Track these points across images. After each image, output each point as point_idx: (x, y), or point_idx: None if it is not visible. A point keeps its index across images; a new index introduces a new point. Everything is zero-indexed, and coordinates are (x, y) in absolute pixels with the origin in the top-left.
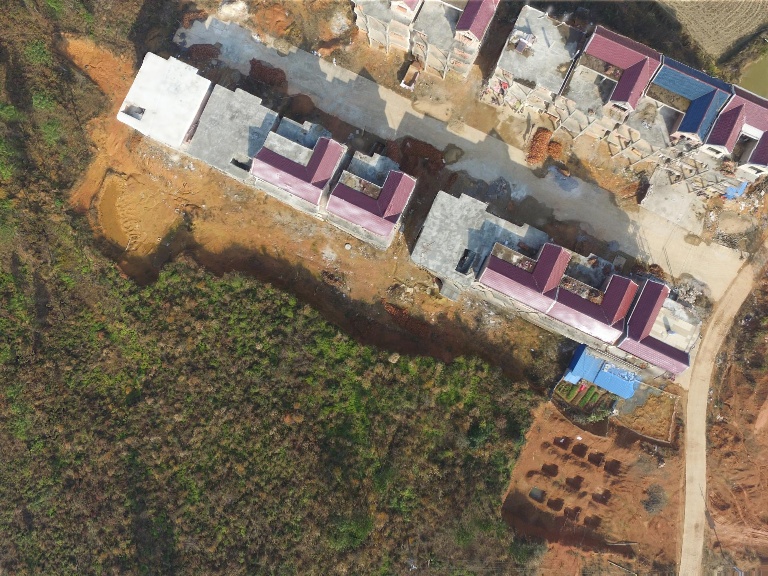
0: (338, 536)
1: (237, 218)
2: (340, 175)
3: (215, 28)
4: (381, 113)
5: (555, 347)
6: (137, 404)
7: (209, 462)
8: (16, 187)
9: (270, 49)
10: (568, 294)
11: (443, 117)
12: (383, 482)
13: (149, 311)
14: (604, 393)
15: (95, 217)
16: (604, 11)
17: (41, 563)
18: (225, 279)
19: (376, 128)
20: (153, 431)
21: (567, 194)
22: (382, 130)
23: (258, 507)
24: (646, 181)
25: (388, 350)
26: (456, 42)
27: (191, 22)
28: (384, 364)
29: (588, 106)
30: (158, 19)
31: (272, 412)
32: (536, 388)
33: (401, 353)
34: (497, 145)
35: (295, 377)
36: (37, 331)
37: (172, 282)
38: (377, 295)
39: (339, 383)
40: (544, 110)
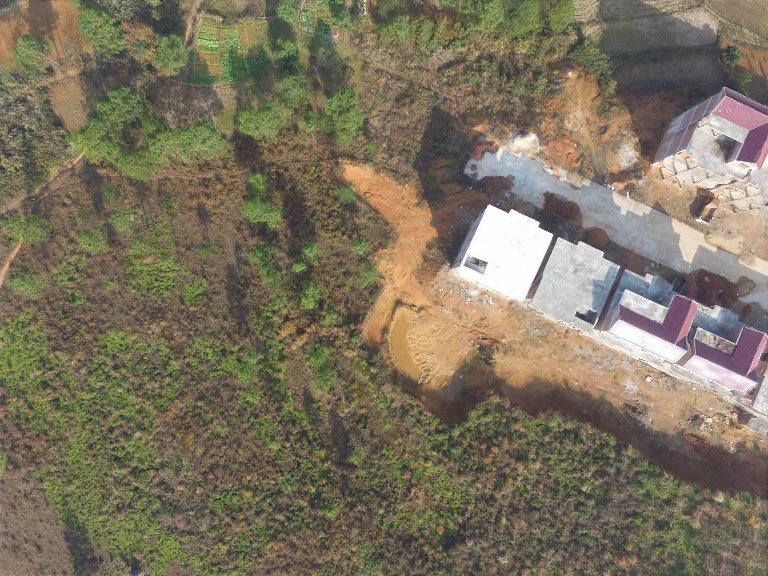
0: None
1: (538, 352)
2: (695, 332)
3: (507, 160)
4: (675, 246)
5: None
6: (456, 546)
7: None
8: (304, 321)
9: (563, 182)
10: None
11: (735, 250)
12: None
13: (460, 450)
14: None
15: (387, 350)
16: None
17: None
18: (541, 419)
19: (671, 261)
20: (479, 575)
21: None
22: (677, 263)
23: None
24: None
25: (708, 487)
26: None
27: (482, 154)
28: (709, 502)
29: None
30: (445, 149)
31: (606, 555)
32: None
33: (717, 488)
34: None
35: (624, 518)
36: (344, 473)
37: (483, 421)
38: (678, 426)
39: (669, 524)
40: None
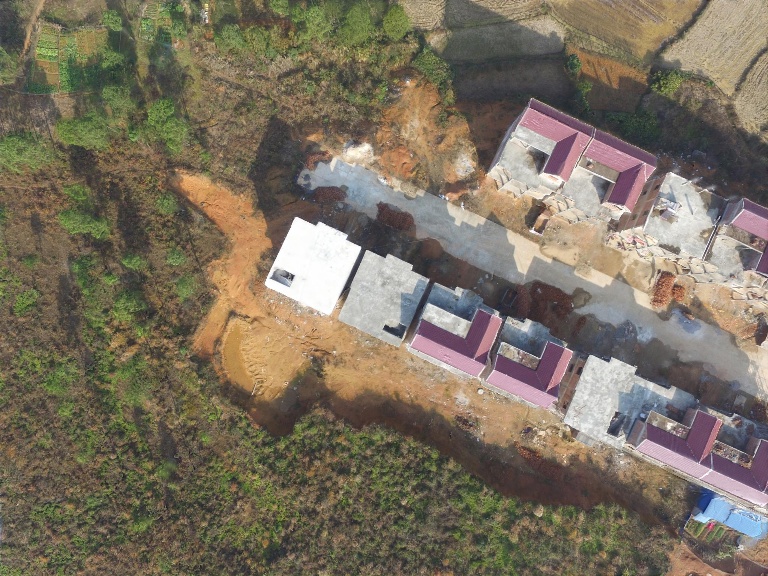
0: None
1: (369, 364)
2: (498, 346)
3: (340, 170)
4: (510, 257)
5: (683, 486)
6: (278, 560)
7: None
8: (135, 332)
9: (397, 192)
10: (721, 460)
11: (571, 262)
12: None
13: (285, 463)
14: (730, 530)
15: (219, 362)
16: (722, 157)
17: None
18: (364, 432)
19: (505, 272)
20: None
21: (690, 336)
22: (511, 274)
23: None
24: (764, 322)
25: (531, 501)
26: (603, 208)
27: (316, 164)
28: (529, 517)
29: (730, 271)
30: (280, 159)
31: (422, 569)
32: (666, 527)
33: (542, 502)
34: (623, 289)
35: (442, 532)
36: (168, 486)
37: (308, 434)
38: (510, 439)
39: (487, 538)
40: (673, 260)
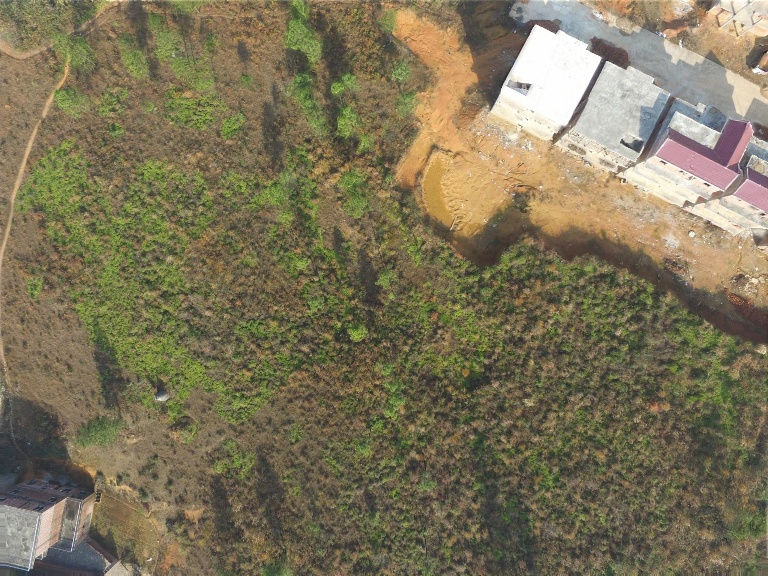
0: (712, 527)
1: (576, 201)
2: (748, 159)
3: (554, 4)
4: (728, 98)
5: None
6: (481, 387)
7: (564, 448)
8: (338, 161)
9: (612, 28)
10: None
11: None
12: (753, 474)
13: (490, 293)
14: None
15: (420, 195)
16: None
17: (386, 545)
18: (576, 263)
19: None
20: (503, 415)
21: None
22: (729, 116)
23: (619, 495)
24: None
25: (750, 341)
26: None
27: None
28: None
29: None
30: None
31: (637, 400)
32: None
33: None
34: None
35: (658, 365)
36: (371, 309)
37: (516, 264)
38: (720, 285)
39: (707, 373)
40: None
